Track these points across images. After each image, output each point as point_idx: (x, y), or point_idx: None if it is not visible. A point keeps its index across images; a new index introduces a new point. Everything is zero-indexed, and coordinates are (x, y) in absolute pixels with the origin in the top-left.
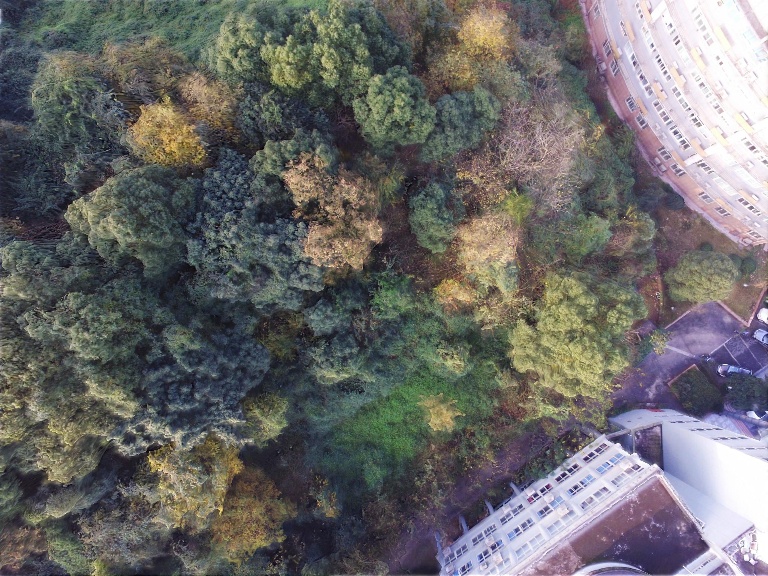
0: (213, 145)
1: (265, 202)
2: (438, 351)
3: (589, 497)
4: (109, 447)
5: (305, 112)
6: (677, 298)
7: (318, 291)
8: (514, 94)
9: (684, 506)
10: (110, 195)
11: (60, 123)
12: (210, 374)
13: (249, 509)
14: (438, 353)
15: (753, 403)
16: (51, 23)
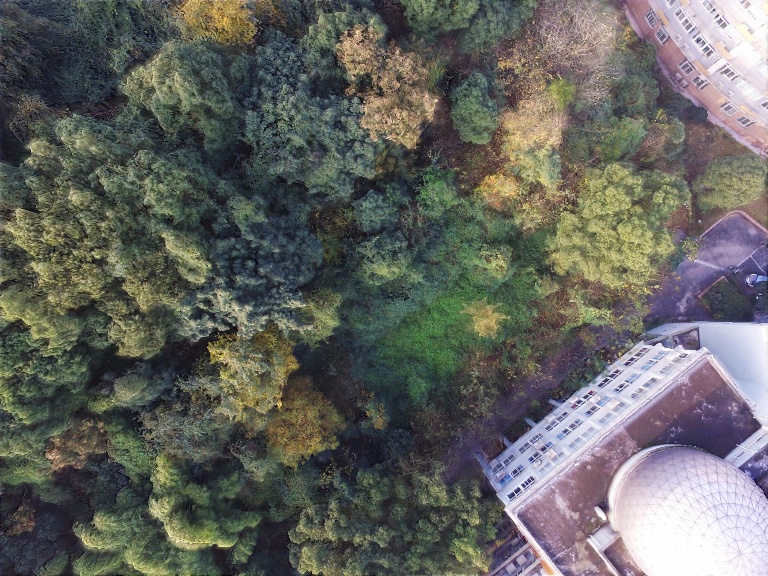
0: (265, 24)
1: (320, 77)
2: (481, 254)
3: (638, 388)
4: (171, 333)
5: None
6: (706, 206)
7: (370, 177)
8: None
9: (734, 386)
10: (173, 58)
11: (106, 14)
12: None
13: (304, 411)
14: (481, 256)
15: None
16: None
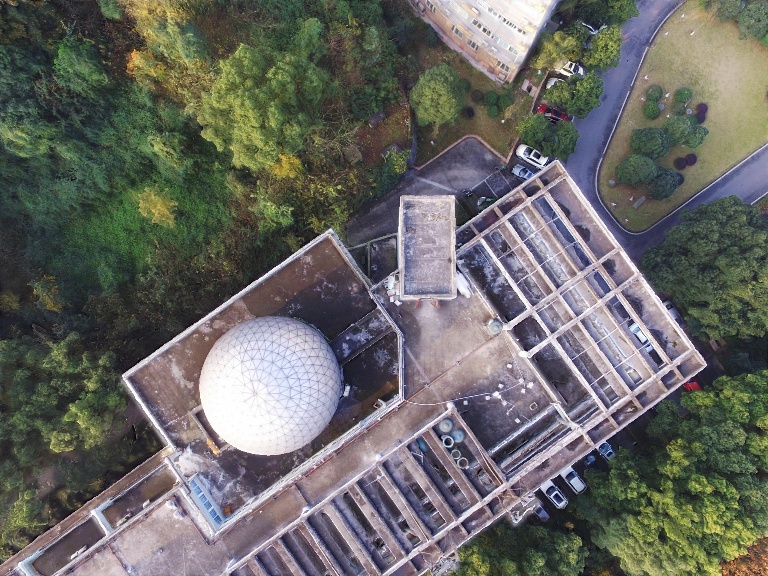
0: None
1: None
2: (148, 139)
3: None
4: None
5: None
6: (423, 123)
7: None
8: None
9: (355, 267)
10: None
11: None
12: None
13: None
14: (147, 140)
15: None
16: None
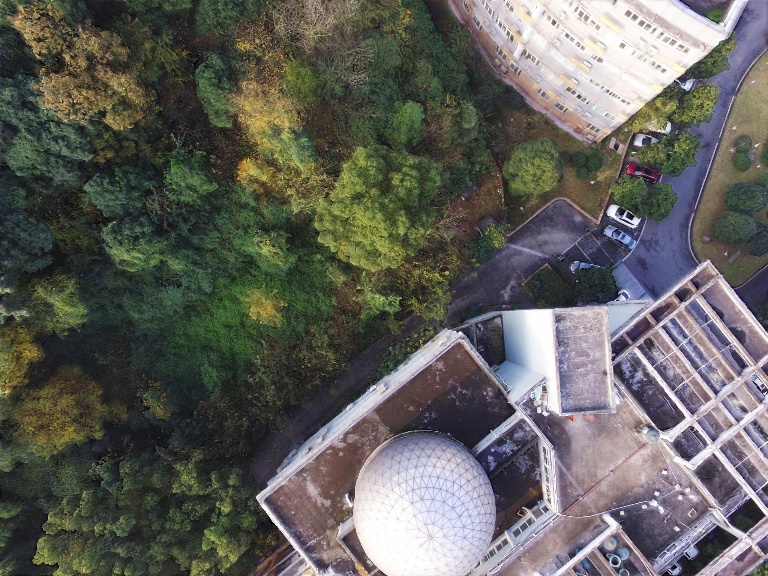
0: None
1: (4, 56)
2: (255, 240)
3: None
4: None
5: None
6: (517, 193)
7: (88, 160)
8: None
9: (489, 371)
10: None
11: None
12: None
13: (52, 400)
14: (254, 242)
15: (596, 293)
16: None
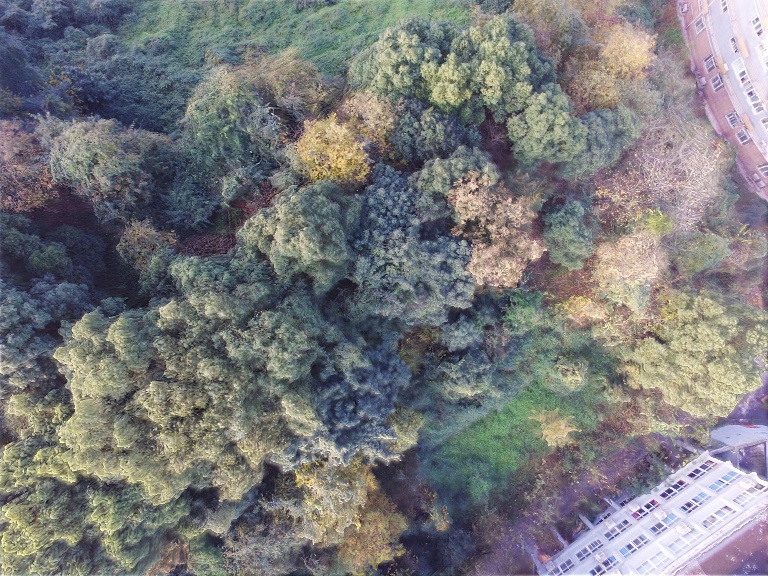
0: (377, 162)
1: (430, 220)
2: (557, 367)
3: (710, 516)
4: None
5: (462, 129)
6: None
7: (465, 308)
8: (652, 112)
9: None
10: (296, 213)
11: (215, 136)
12: (370, 391)
13: (376, 523)
14: (557, 369)
15: None
16: (147, 29)
